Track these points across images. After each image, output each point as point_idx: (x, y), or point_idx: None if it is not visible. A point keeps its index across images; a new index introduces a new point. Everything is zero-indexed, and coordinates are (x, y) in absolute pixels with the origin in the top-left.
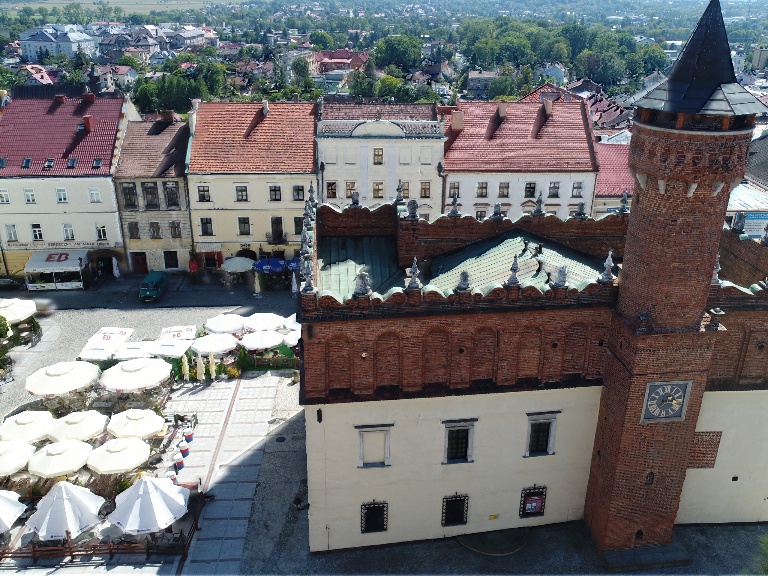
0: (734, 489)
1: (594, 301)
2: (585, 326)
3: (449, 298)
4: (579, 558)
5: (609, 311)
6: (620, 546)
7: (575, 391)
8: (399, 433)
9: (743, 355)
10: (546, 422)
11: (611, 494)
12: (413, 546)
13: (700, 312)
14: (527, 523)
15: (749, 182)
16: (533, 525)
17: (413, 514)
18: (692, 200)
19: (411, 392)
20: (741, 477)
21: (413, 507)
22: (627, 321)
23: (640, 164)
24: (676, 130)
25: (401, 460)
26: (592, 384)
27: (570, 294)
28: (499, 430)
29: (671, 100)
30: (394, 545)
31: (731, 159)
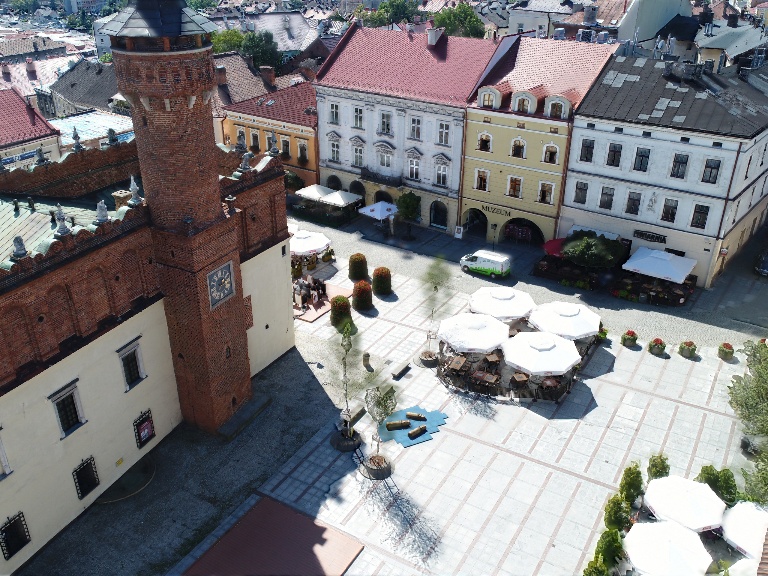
0: (269, 335)
1: (134, 225)
2: (133, 251)
3: (11, 270)
4: (202, 448)
5: (148, 230)
6: (226, 419)
7: (145, 312)
8: (10, 433)
9: (245, 230)
10: (132, 352)
11: (208, 380)
12: (61, 537)
13: (220, 203)
14: (146, 451)
15: (97, 110)
16: (150, 449)
17: (50, 507)
18: (193, 111)
19: (7, 384)
20: (270, 324)
21: (48, 500)
22: (174, 230)
23: (141, 89)
24: (166, 53)
25: (21, 460)
26: (156, 300)
27: (114, 226)
28: (99, 379)
29: (152, 27)
30: (43, 550)
31: (210, 71)
